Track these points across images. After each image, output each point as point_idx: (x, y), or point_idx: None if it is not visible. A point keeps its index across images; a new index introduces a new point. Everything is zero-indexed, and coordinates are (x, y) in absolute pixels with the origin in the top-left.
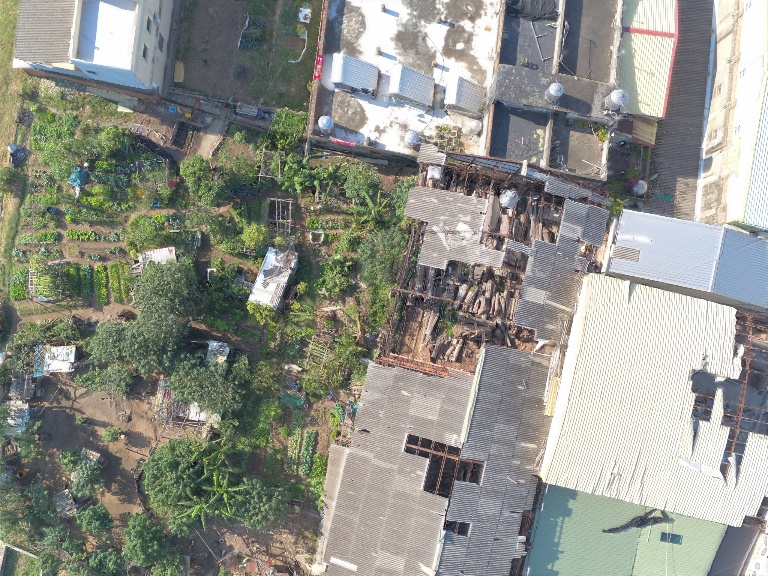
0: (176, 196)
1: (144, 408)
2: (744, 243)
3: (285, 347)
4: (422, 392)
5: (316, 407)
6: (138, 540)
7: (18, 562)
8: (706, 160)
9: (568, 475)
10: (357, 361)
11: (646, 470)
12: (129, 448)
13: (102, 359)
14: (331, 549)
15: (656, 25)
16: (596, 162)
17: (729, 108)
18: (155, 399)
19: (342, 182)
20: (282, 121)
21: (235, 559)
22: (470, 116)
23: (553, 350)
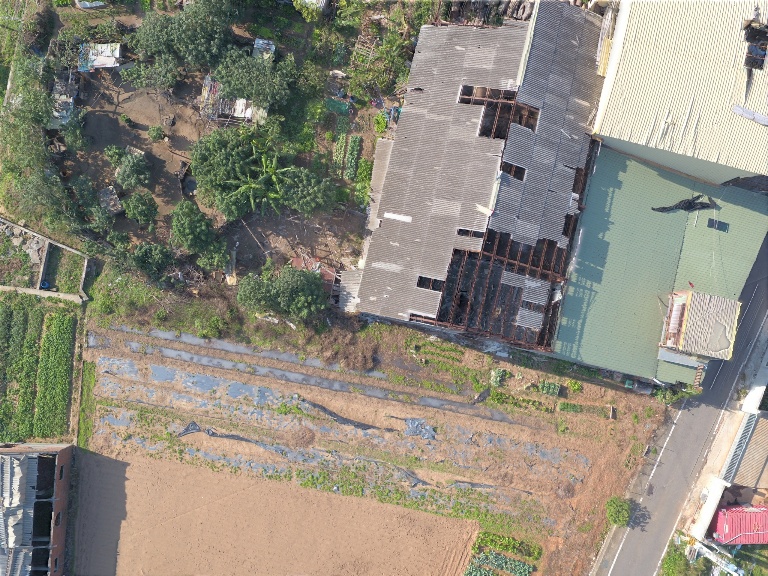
0: None
1: (188, 113)
2: None
3: (329, 55)
4: (476, 44)
5: (360, 114)
6: (186, 218)
7: (61, 261)
8: None
9: (622, 125)
10: (402, 63)
11: (699, 119)
12: (173, 151)
13: (148, 52)
14: (385, 205)
15: None
16: None
17: None
18: (200, 95)
19: None
20: None
21: (281, 256)
22: None
23: (605, 11)
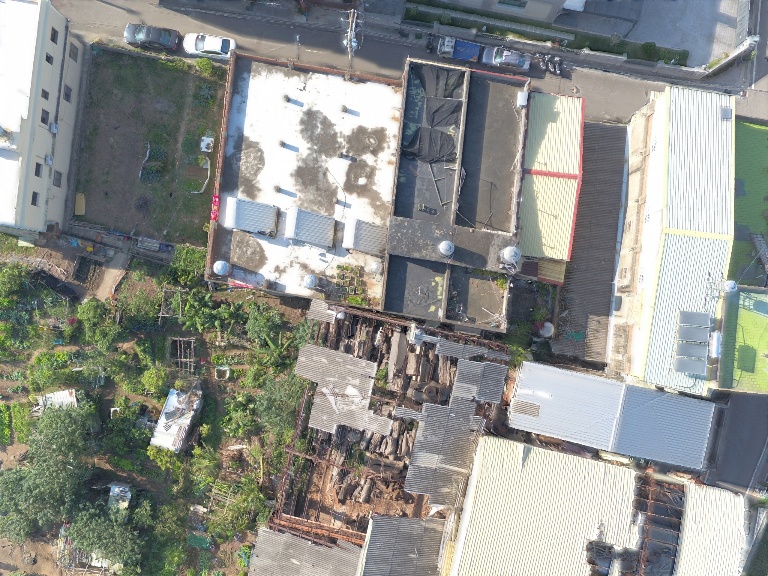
0: (79, 333)
1: (49, 550)
2: (647, 399)
3: (191, 487)
4: (310, 561)
5: (223, 548)
6: None
7: None
8: (617, 297)
9: None
10: (262, 504)
11: None
12: None
13: None
14: None
15: (559, 166)
16: (497, 310)
17: (636, 251)
18: (57, 546)
19: (244, 321)
20: (183, 258)
21: None
22: (373, 254)
23: (447, 514)
